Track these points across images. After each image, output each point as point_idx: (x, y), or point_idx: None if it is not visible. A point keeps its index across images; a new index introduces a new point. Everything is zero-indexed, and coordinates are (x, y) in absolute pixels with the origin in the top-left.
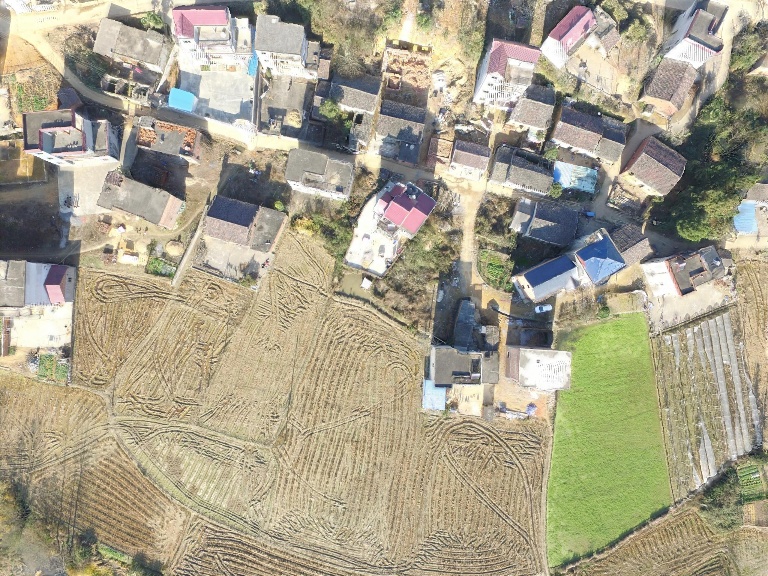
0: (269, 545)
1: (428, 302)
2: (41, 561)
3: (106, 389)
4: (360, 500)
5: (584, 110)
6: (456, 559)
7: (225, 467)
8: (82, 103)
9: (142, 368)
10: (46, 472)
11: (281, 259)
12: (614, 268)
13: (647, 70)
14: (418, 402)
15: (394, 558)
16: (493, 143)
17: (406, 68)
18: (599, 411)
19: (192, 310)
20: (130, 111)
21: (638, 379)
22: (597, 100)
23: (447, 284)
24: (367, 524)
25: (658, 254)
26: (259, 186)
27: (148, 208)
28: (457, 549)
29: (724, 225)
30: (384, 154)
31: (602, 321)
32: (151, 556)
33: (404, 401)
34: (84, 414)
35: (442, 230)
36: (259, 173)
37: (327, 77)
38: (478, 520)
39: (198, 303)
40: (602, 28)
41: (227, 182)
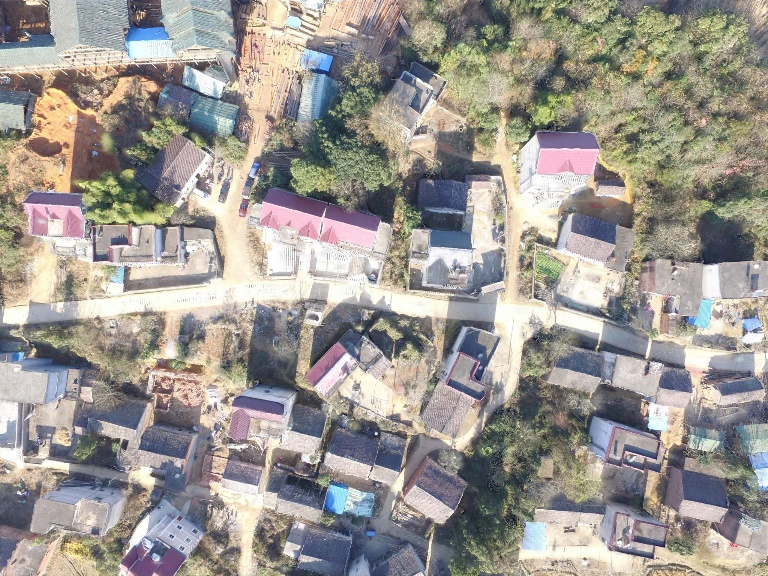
0: None
1: None
2: None
3: None
4: None
5: (365, 424)
6: None
7: None
8: None
9: None
10: None
11: None
12: None
13: (426, 388)
14: None
15: None
16: (270, 458)
17: (177, 385)
18: None
19: None
20: None
21: None
22: (375, 418)
23: None
24: None
25: (443, 573)
26: (29, 505)
27: None
28: None
29: (498, 564)
30: (157, 471)
31: None
32: None
33: None
34: None
35: None
36: (27, 494)
37: (91, 401)
38: None
39: None
40: (369, 358)
41: None
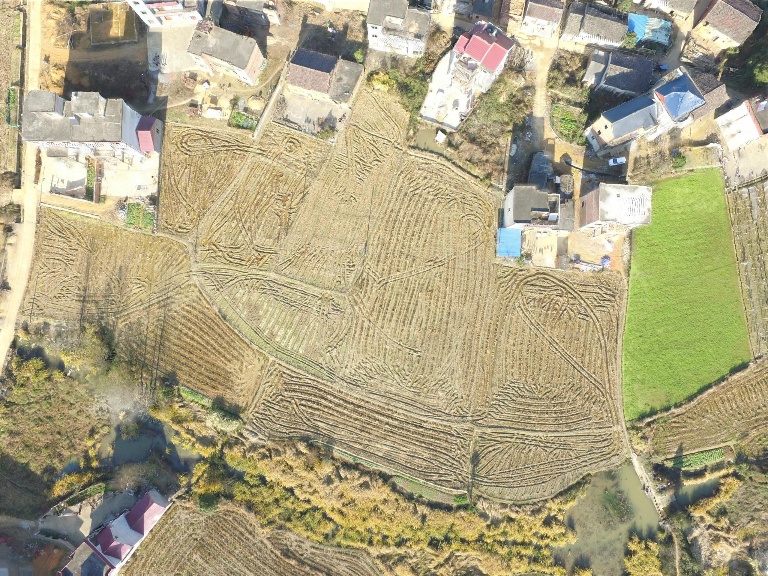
0: (345, 391)
1: (501, 156)
2: (125, 403)
3: (189, 237)
4: (434, 348)
5: None
6: (531, 409)
7: (302, 314)
8: None
9: (224, 218)
10: (131, 317)
11: (357, 115)
12: (694, 104)
13: None
14: (492, 253)
15: (468, 407)
16: (565, 1)
17: None
18: (675, 265)
19: (272, 163)
20: None
21: (714, 234)
22: None
23: (520, 139)
24: (441, 372)
25: (733, 107)
26: (336, 45)
27: (235, 54)
28: (532, 399)
29: None
30: (457, 13)
31: (676, 176)
32: (230, 399)
33: (478, 252)
34: (168, 261)
35: None
36: (337, 32)
37: None
38: (553, 371)
39: (277, 156)
40: None
41: (306, 41)
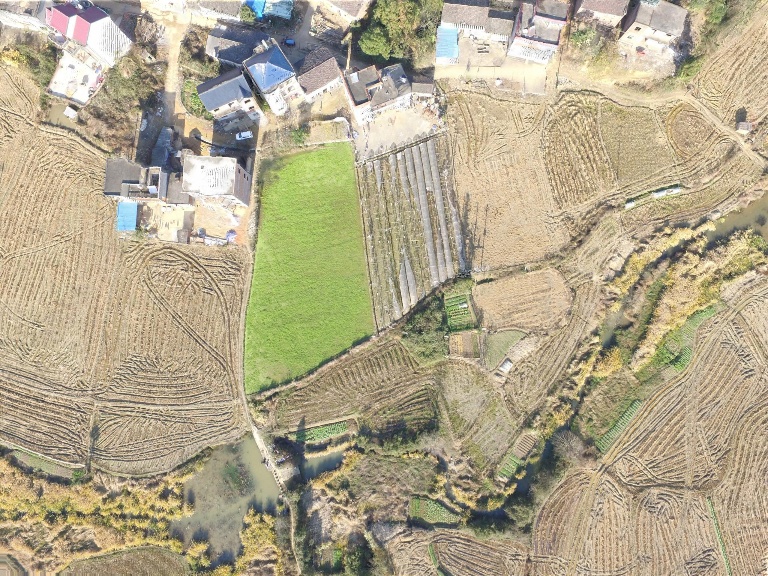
0: None
1: (132, 131)
2: None
3: None
4: (58, 323)
5: None
6: (152, 383)
7: None
8: None
9: None
10: None
11: None
12: (281, 76)
13: None
14: None
15: (89, 381)
16: None
17: None
18: (301, 239)
19: None
20: None
21: (342, 208)
22: None
23: (151, 114)
24: (64, 347)
25: None
26: None
27: None
28: (153, 373)
29: (405, 40)
30: None
31: (307, 150)
32: None
33: (105, 227)
34: None
35: (146, 61)
36: None
37: None
38: (175, 345)
39: None
40: None
41: None
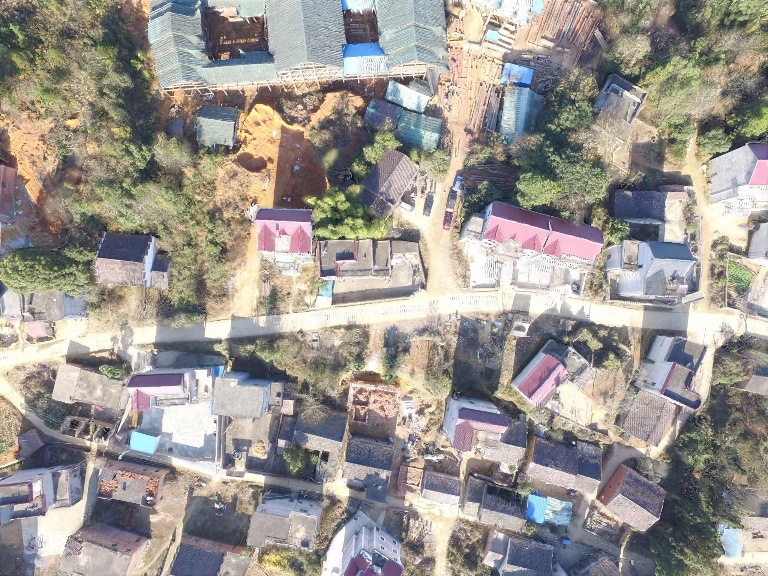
0: None
1: None
2: None
3: None
4: None
5: (559, 433)
6: None
7: None
8: (43, 443)
9: None
10: None
11: None
12: None
13: (623, 397)
14: None
15: None
16: (465, 469)
17: (373, 397)
18: None
19: None
20: (92, 447)
21: None
22: (572, 428)
23: None
24: None
25: None
26: (225, 518)
27: (110, 572)
28: None
29: (704, 571)
30: (352, 483)
31: None
32: None
33: None
34: None
35: None
36: (225, 507)
37: (291, 413)
38: None
39: None
40: (574, 368)
41: (192, 516)
